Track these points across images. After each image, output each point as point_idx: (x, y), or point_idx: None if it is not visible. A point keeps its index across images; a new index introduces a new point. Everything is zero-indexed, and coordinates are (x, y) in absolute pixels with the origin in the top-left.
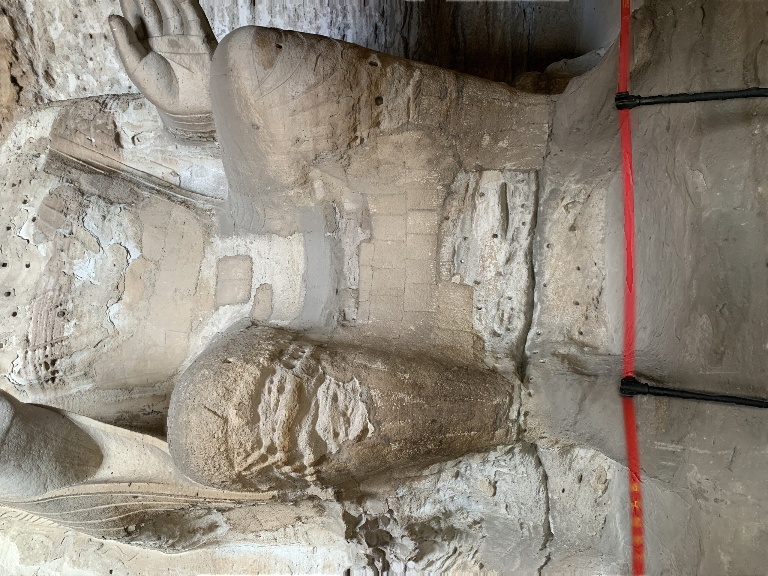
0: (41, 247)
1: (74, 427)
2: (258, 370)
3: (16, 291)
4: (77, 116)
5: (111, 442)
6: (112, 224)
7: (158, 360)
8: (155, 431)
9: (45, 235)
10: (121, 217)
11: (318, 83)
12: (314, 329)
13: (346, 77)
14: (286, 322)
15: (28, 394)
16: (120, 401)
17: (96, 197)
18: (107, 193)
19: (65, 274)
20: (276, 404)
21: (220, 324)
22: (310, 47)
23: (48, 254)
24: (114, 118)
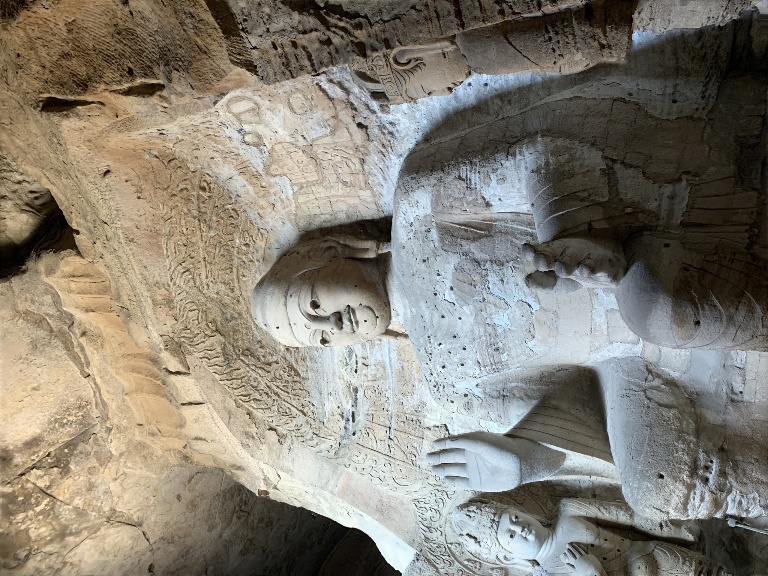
0: (465, 308)
1: (547, 449)
2: (685, 489)
3: (459, 335)
4: (449, 196)
5: (571, 454)
6: (510, 285)
7: (567, 361)
8: (570, 388)
9: (466, 302)
10: (515, 277)
11: (736, 345)
12: (706, 397)
13: (765, 339)
14: (677, 374)
15: (484, 376)
16: (540, 368)
17: (490, 263)
18: (495, 255)
19: (489, 325)
20: (699, 505)
21: (615, 353)
22: (729, 321)
23: (472, 313)
24: (482, 194)
